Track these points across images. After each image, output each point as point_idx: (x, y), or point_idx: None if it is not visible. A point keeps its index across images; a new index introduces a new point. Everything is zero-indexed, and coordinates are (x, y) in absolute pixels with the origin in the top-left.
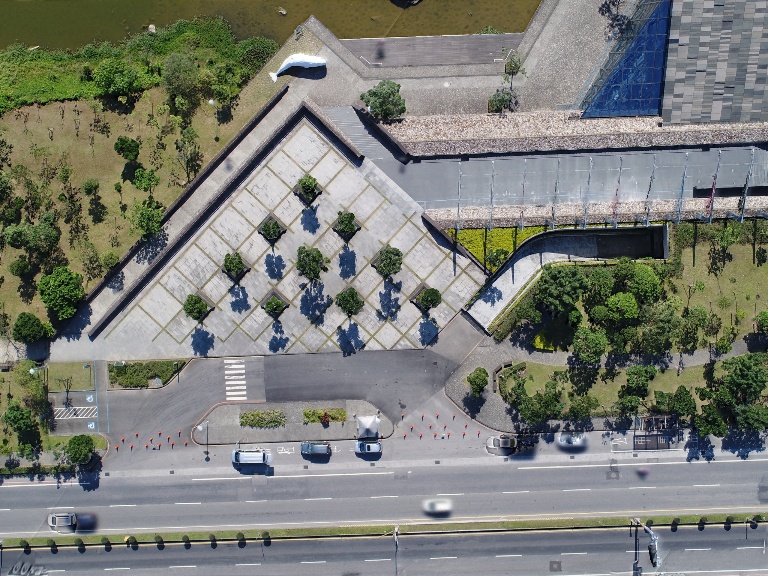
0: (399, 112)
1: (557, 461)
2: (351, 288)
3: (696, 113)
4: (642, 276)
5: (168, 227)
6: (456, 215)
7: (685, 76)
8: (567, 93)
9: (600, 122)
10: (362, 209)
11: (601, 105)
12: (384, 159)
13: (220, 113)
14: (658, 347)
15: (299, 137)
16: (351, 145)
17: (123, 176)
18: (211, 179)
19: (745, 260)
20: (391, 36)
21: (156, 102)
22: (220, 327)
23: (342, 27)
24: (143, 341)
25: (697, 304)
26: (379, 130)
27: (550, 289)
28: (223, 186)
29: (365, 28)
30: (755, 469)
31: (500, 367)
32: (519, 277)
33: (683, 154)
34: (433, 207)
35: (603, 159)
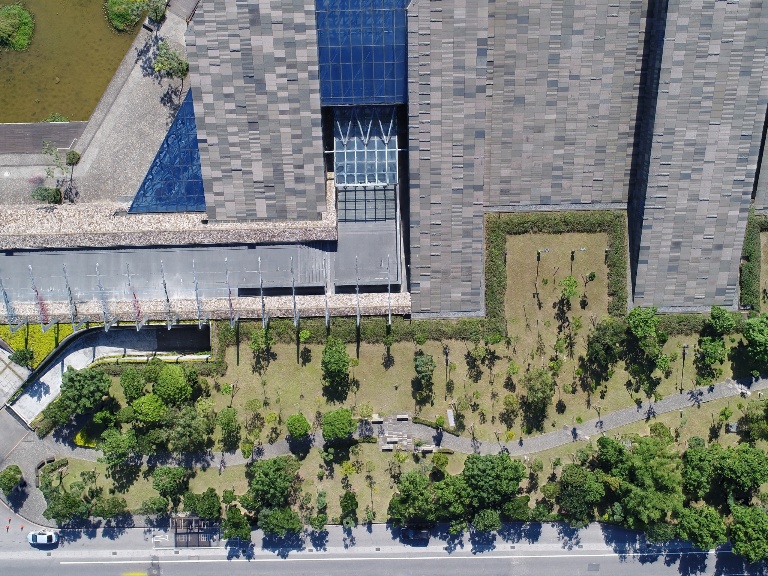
0: None
1: (99, 556)
2: None
3: (241, 210)
4: (164, 379)
5: None
6: None
7: (222, 175)
8: (128, 184)
9: (144, 218)
10: None
11: (159, 198)
12: None
13: None
14: (200, 445)
15: None
16: None
17: None
18: None
19: (290, 359)
20: None
21: None
22: None
23: None
24: None
25: (240, 403)
26: None
27: (66, 392)
28: None
29: None
30: (295, 568)
31: (42, 463)
32: None
33: (229, 252)
34: None
35: (148, 255)
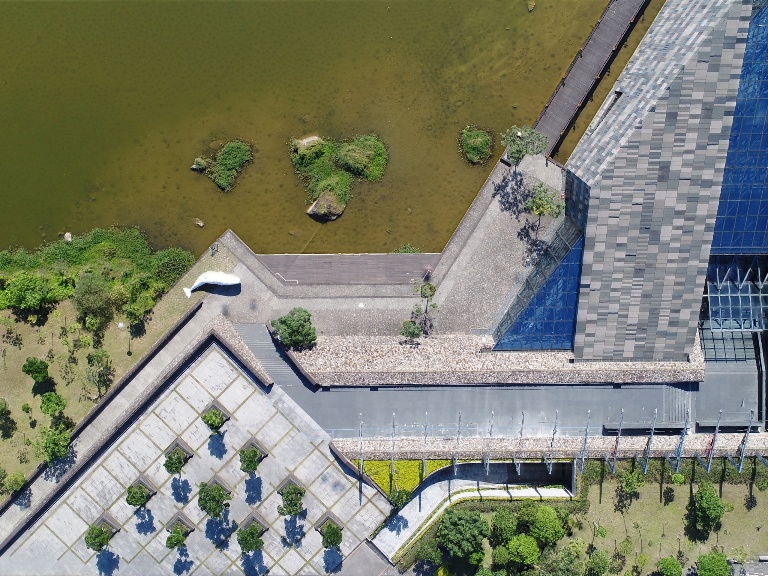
0: (309, 341)
1: None
2: (252, 526)
3: (608, 351)
4: (543, 523)
5: (77, 444)
6: (363, 446)
7: (597, 317)
8: (482, 318)
9: (511, 356)
10: (270, 436)
11: (516, 332)
12: (293, 386)
13: (133, 327)
14: None
15: (208, 362)
16: (259, 374)
17: (34, 390)
18: (121, 396)
19: (652, 499)
20: (308, 251)
21: (69, 314)
22: (125, 548)
23: (259, 240)
24: (49, 559)
25: (602, 541)
26: (289, 357)
27: (449, 536)
28: (131, 410)
29: (282, 242)
30: None
31: None
32: (426, 505)
33: (594, 391)
34: (341, 436)
35: (513, 393)
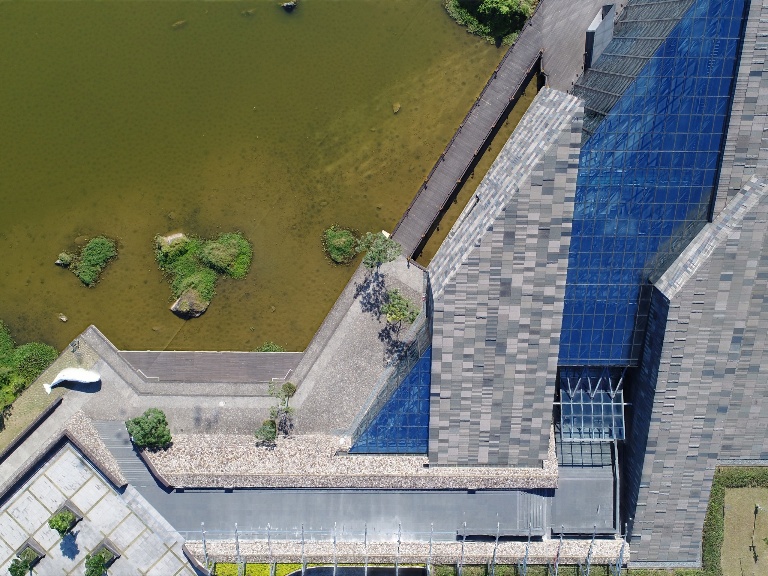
0: (163, 443)
1: None
2: None
3: (463, 456)
4: None
5: None
6: (215, 549)
7: (449, 424)
8: (343, 418)
9: (366, 460)
10: (123, 537)
11: (375, 433)
12: (148, 487)
13: None
14: None
15: (62, 462)
16: (112, 475)
17: None
18: None
19: None
20: (172, 347)
21: None
22: None
23: (123, 336)
24: None
25: None
26: None
27: None
28: None
29: (146, 338)
30: None
31: None
32: None
33: (448, 496)
34: (194, 538)
35: (368, 497)
